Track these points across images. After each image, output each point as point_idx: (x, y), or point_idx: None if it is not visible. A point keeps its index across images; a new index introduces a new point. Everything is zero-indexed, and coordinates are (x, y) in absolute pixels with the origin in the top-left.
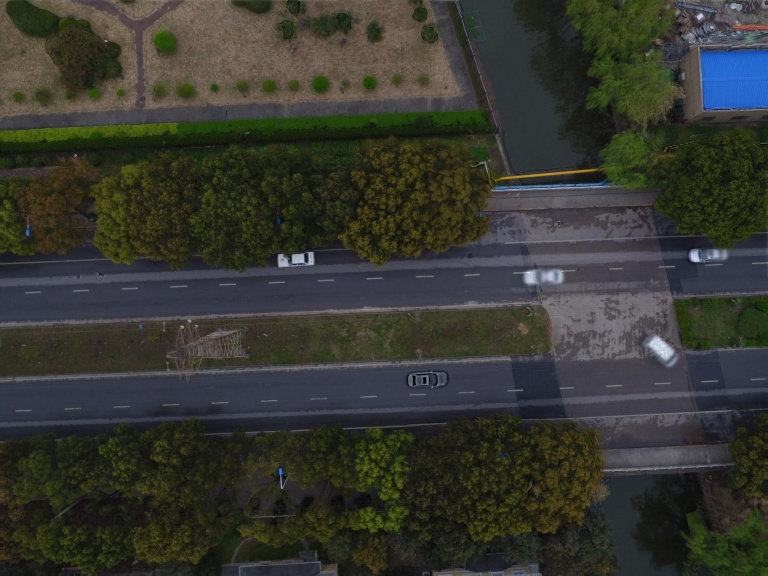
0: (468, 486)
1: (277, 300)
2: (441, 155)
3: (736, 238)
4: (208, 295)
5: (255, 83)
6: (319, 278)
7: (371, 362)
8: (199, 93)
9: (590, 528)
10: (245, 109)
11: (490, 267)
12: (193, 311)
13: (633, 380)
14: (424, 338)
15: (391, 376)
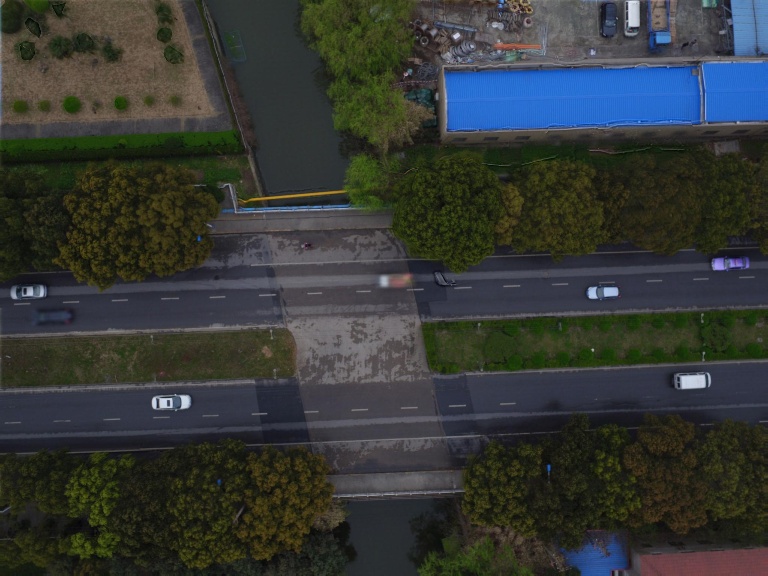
0: (174, 513)
1: (22, 322)
2: (157, 179)
3: (469, 262)
4: None
5: (7, 103)
6: (64, 300)
7: (114, 384)
8: None
9: (310, 556)
10: None
11: (235, 289)
12: None
13: (379, 404)
14: (167, 361)
15: (135, 399)
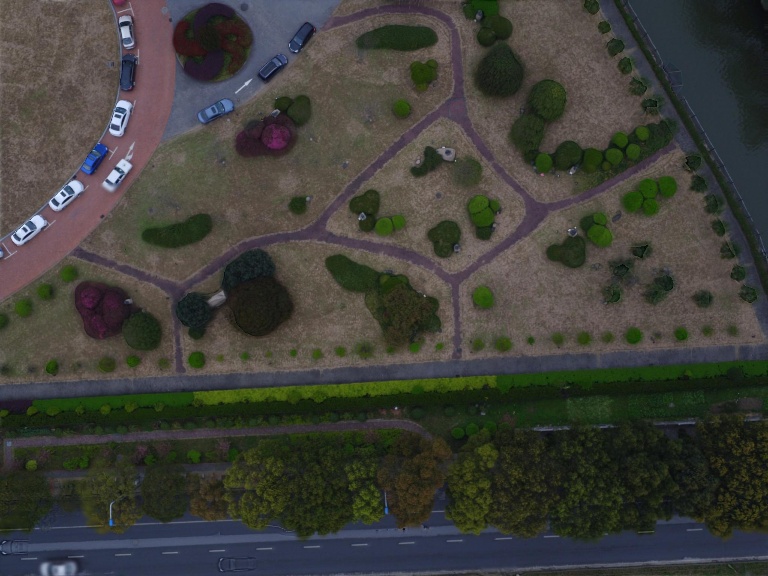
0: None
1: (599, 552)
2: None
3: None
4: (532, 547)
5: (568, 334)
6: (639, 530)
7: None
8: (514, 344)
9: None
10: (559, 359)
11: None
12: (518, 563)
13: None
14: None
15: None
